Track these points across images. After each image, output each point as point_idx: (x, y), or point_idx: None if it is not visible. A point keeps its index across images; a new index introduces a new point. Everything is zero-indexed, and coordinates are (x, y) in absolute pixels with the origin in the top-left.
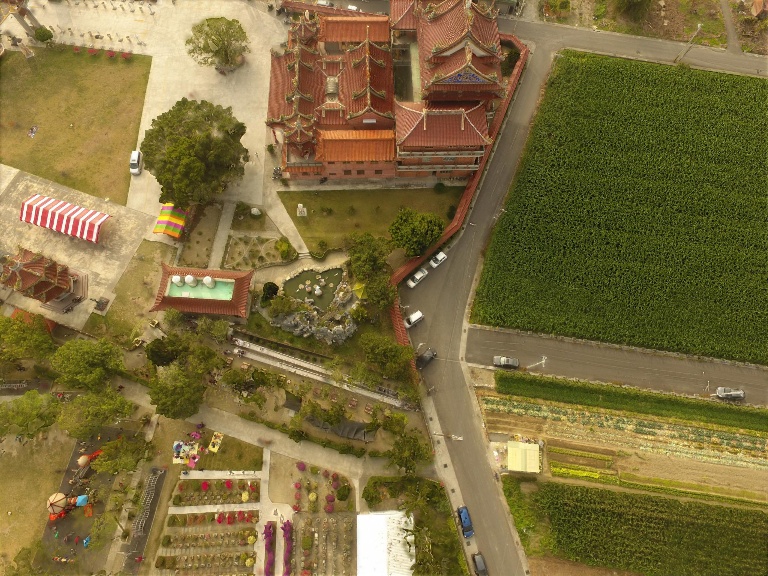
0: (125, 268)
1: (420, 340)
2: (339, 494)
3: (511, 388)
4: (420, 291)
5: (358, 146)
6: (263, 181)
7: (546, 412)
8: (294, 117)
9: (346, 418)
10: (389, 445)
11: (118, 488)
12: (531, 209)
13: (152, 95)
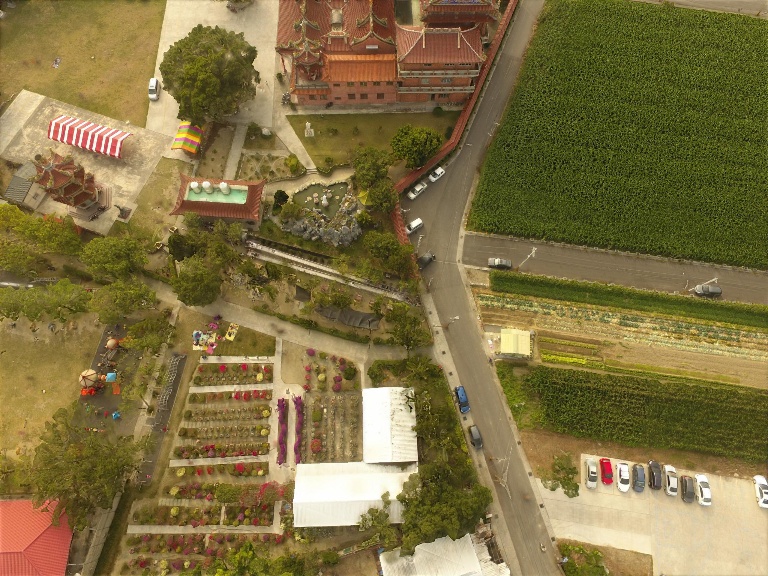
0: (145, 182)
1: (420, 245)
2: (346, 374)
3: (504, 286)
4: (420, 202)
5: (362, 67)
6: (273, 106)
7: (537, 307)
8: (302, 42)
9: (352, 309)
10: (392, 335)
11: None
12: (523, 130)
13: (168, 30)
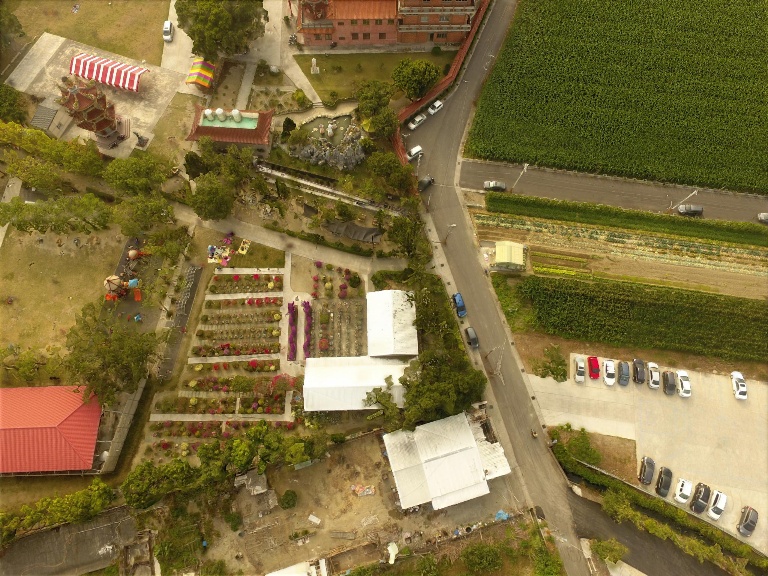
0: (161, 114)
1: (420, 170)
2: (351, 281)
3: (499, 207)
4: (420, 133)
5: (364, 6)
6: (280, 47)
7: (530, 226)
8: None
9: (356, 225)
10: None
11: (162, 280)
12: (517, 67)
13: None
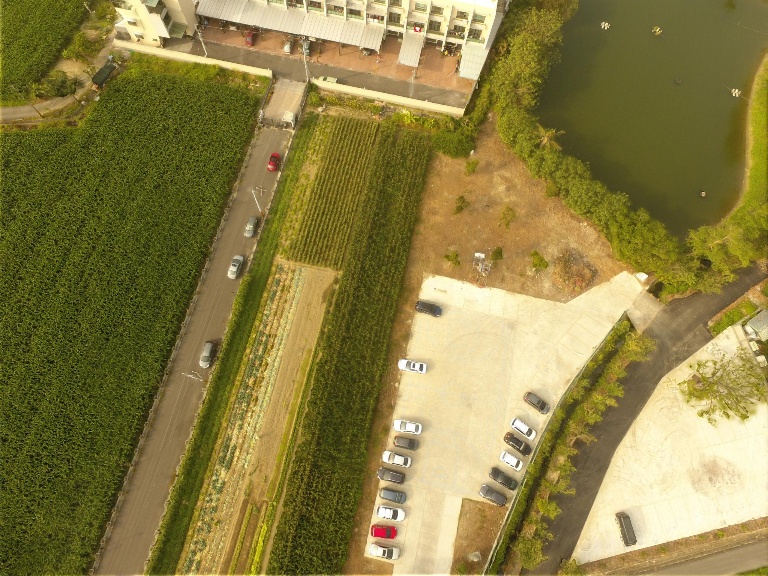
0: None
1: None
2: None
3: None
4: None
5: None
6: None
7: None
8: None
9: None
10: None
11: None
12: None
13: None
